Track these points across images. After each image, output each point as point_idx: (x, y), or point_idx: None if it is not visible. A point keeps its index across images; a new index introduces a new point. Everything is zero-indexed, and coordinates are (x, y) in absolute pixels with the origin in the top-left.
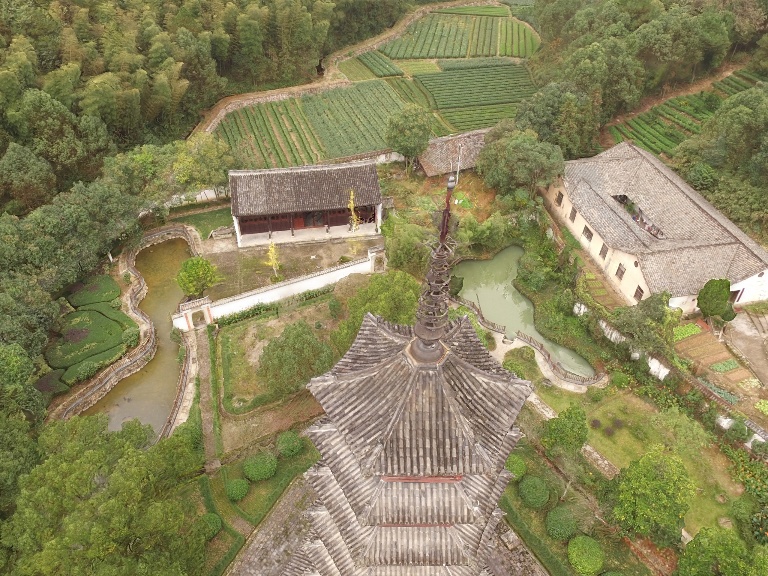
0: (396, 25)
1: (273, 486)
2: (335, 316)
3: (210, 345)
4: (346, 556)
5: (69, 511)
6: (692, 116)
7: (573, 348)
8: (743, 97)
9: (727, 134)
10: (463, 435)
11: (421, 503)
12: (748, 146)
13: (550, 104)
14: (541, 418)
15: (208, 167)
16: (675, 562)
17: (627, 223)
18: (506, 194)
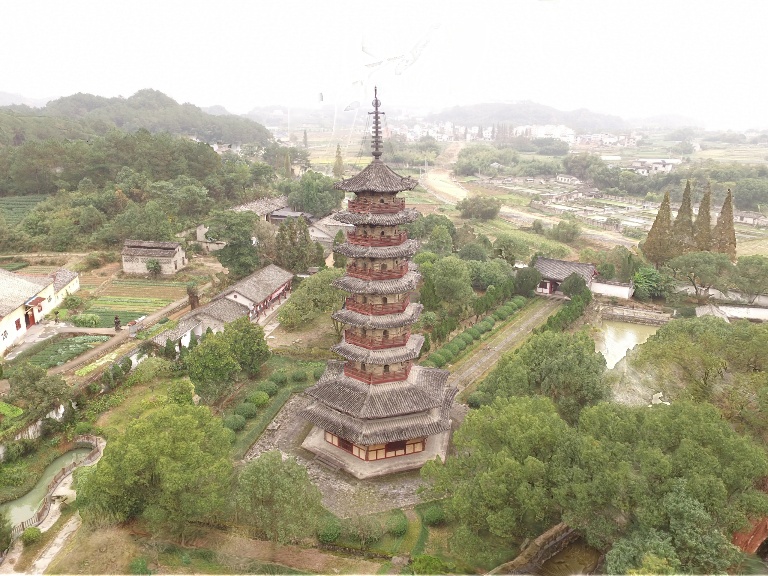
0: None
1: None
2: None
3: None
4: (413, 281)
5: None
6: None
7: None
8: None
9: None
10: None
11: None
12: None
13: None
14: None
15: None
16: None
17: None
18: None
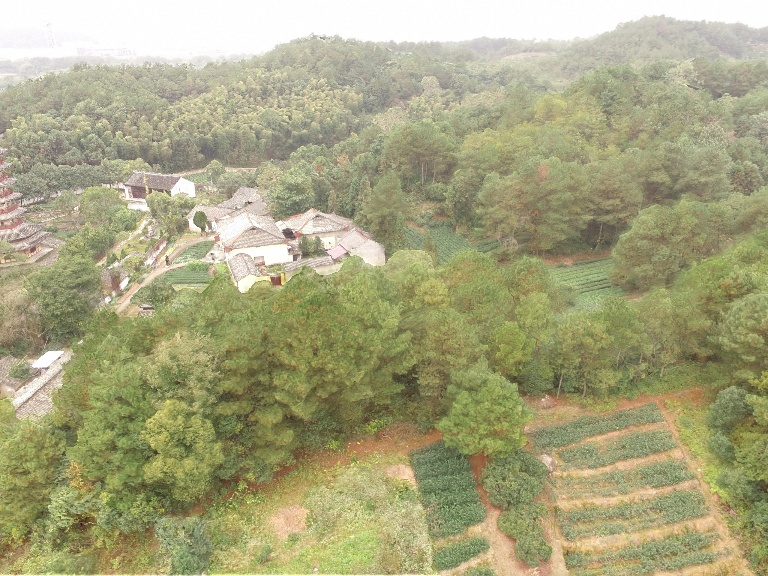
0: None
1: None
2: None
3: None
4: None
5: None
6: None
7: None
8: None
9: None
10: None
11: None
12: None
13: None
14: (120, 242)
15: None
16: None
17: (224, 203)
18: None
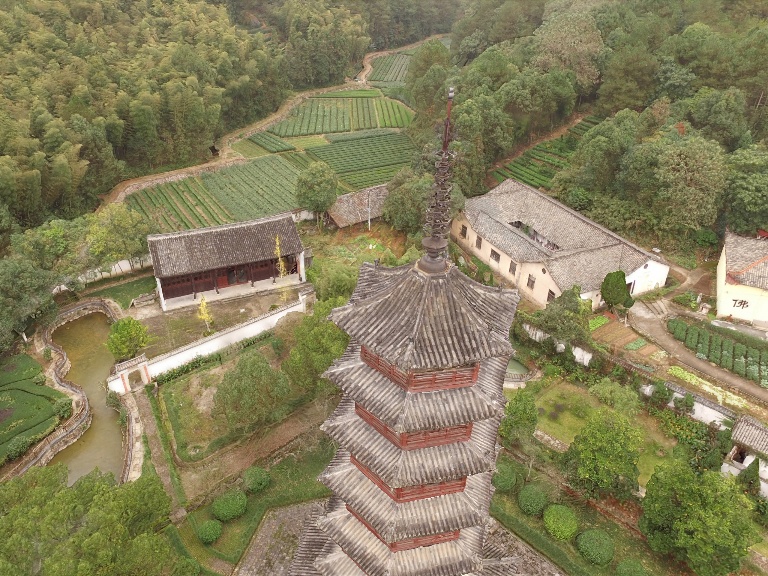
0: (280, 109)
1: (246, 523)
2: (279, 354)
3: (152, 403)
4: (369, 505)
5: (47, 556)
6: (558, 155)
7: None
8: (598, 129)
9: (592, 160)
10: (477, 329)
11: (446, 409)
12: (610, 169)
13: None
14: None
15: (123, 237)
16: (638, 512)
17: (528, 240)
18: (416, 232)
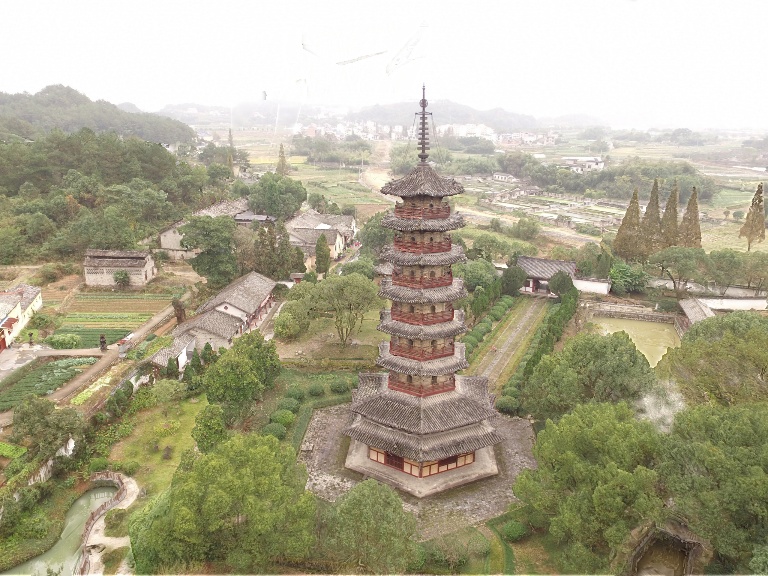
0: None
1: None
2: None
3: None
4: None
5: None
6: None
7: None
8: None
9: None
10: None
11: None
12: None
13: None
14: None
15: None
16: None
17: None
18: None
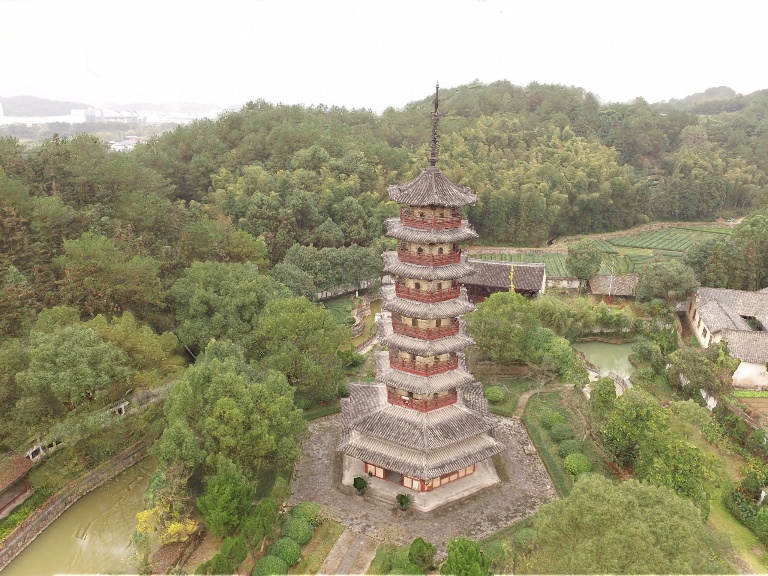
0: (630, 229)
1: None
2: None
3: None
4: None
5: None
6: None
7: (653, 392)
8: None
9: None
10: None
11: (415, 236)
12: None
13: (703, 250)
14: None
15: None
16: None
17: (734, 321)
18: None
